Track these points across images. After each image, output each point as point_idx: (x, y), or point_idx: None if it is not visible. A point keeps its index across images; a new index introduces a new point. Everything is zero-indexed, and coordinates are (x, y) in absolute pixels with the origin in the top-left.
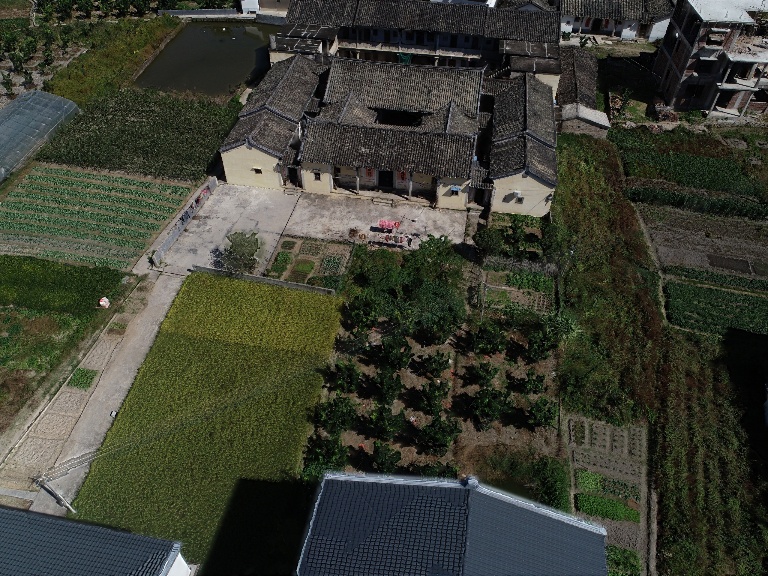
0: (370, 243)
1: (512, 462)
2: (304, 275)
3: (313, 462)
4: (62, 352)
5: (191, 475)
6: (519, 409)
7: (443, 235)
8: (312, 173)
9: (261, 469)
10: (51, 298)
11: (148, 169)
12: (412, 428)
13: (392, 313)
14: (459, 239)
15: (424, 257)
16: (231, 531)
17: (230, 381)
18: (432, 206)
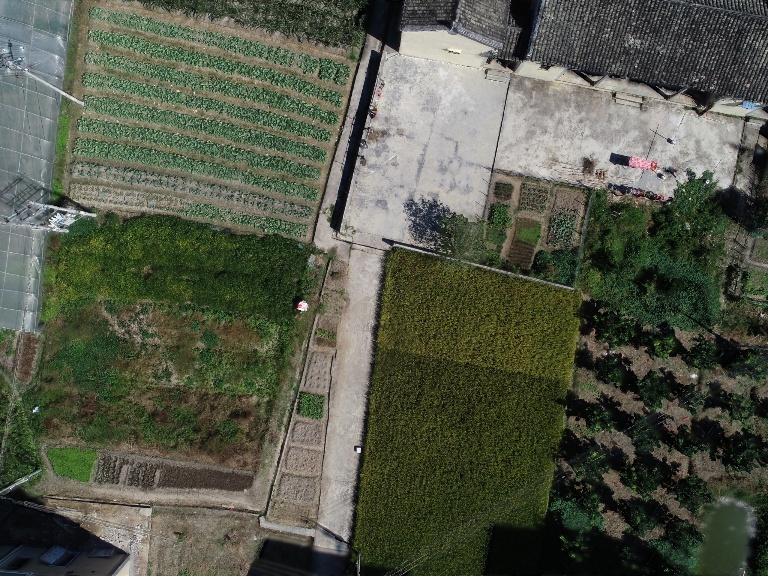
0: (610, 187)
1: (740, 492)
2: (530, 249)
3: (558, 497)
4: (278, 375)
5: (452, 518)
6: (758, 437)
7: (707, 172)
8: (539, 64)
9: (515, 513)
10: (235, 297)
11: (276, 26)
12: (650, 458)
13: (636, 311)
14: (727, 179)
15: (683, 223)
16: (498, 570)
17: (469, 414)
18: (697, 108)
